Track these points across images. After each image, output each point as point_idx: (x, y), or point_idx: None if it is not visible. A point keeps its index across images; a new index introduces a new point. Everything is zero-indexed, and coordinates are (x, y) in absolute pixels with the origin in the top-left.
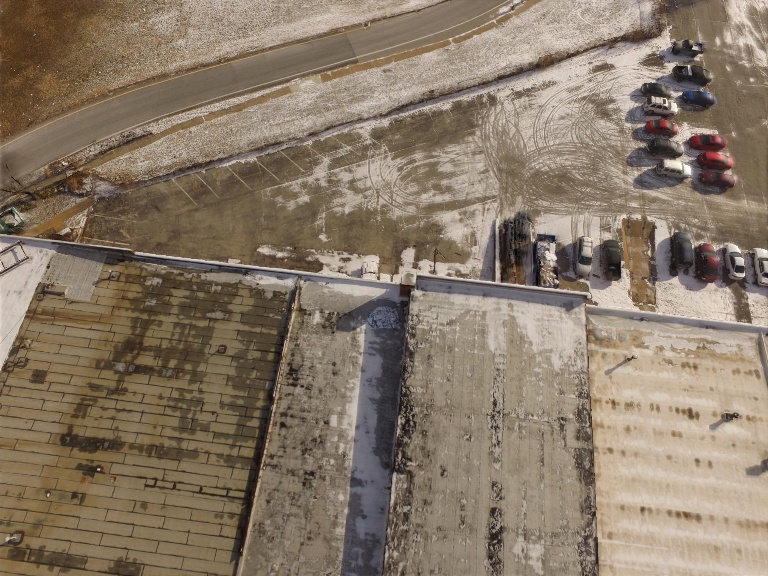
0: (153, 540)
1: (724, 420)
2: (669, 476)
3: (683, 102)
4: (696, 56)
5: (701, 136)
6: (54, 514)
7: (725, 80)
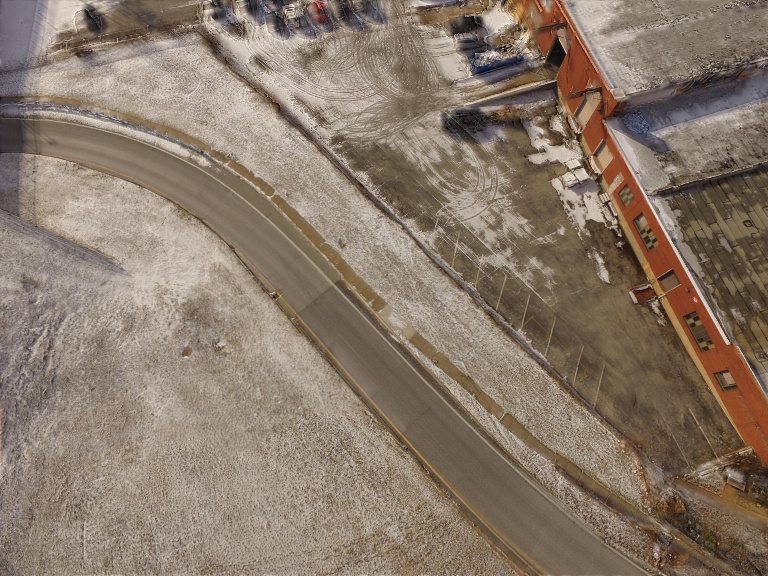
0: None
1: None
2: None
3: (275, 5)
4: None
5: None
6: None
7: None
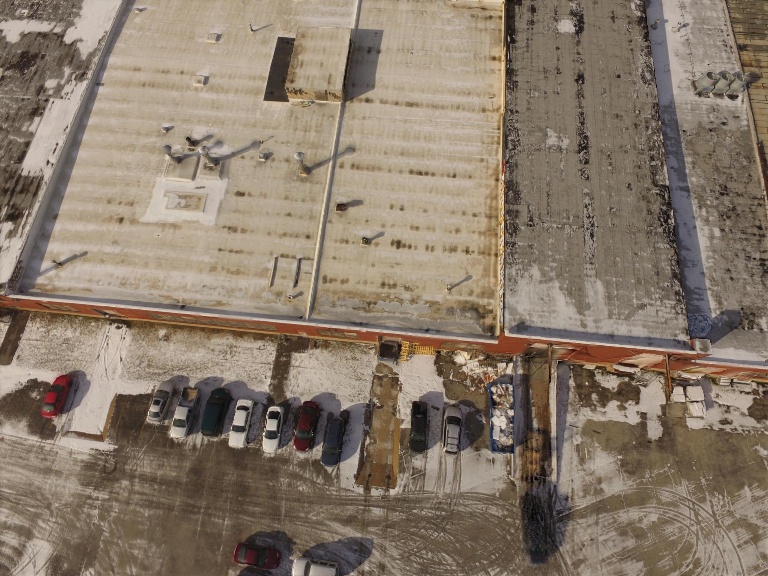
0: None
1: (370, 240)
2: (428, 198)
3: None
4: None
5: None
6: None
7: None
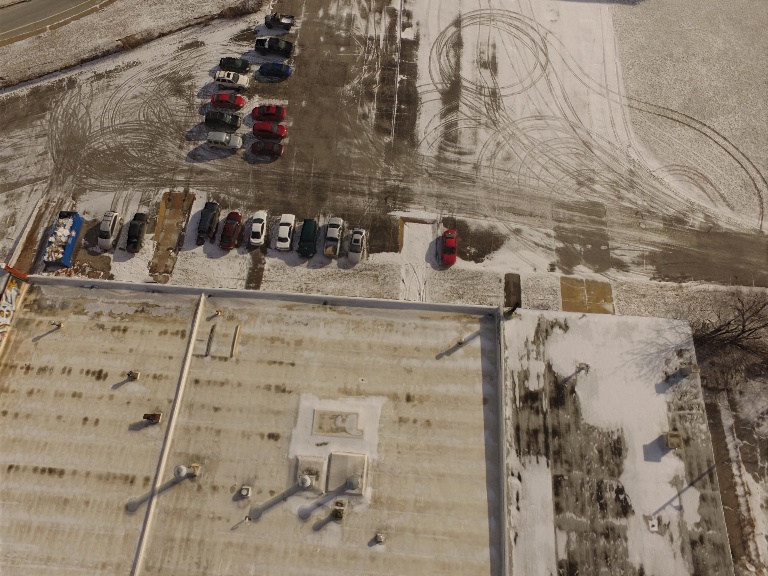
0: None
1: (130, 379)
2: (51, 435)
3: (261, 75)
4: (291, 29)
5: (260, 107)
6: None
7: (314, 51)
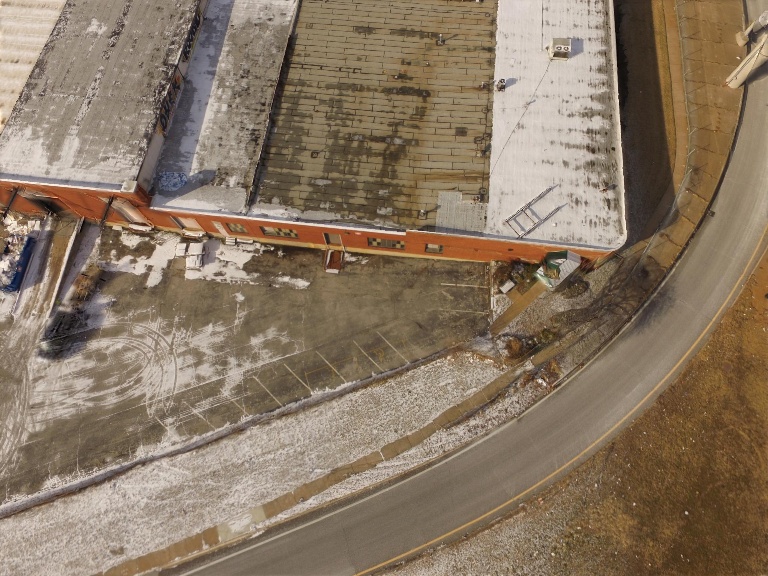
0: (350, 43)
1: None
2: None
3: None
4: None
5: None
6: (420, 54)
7: None
